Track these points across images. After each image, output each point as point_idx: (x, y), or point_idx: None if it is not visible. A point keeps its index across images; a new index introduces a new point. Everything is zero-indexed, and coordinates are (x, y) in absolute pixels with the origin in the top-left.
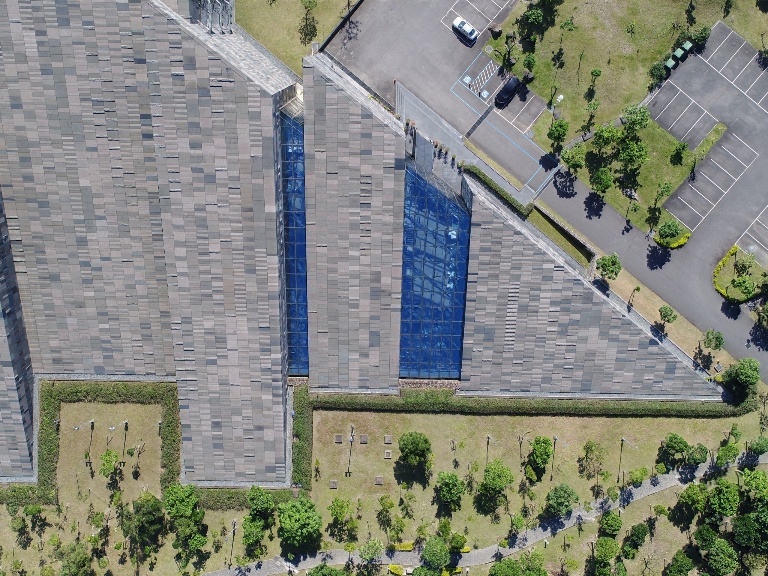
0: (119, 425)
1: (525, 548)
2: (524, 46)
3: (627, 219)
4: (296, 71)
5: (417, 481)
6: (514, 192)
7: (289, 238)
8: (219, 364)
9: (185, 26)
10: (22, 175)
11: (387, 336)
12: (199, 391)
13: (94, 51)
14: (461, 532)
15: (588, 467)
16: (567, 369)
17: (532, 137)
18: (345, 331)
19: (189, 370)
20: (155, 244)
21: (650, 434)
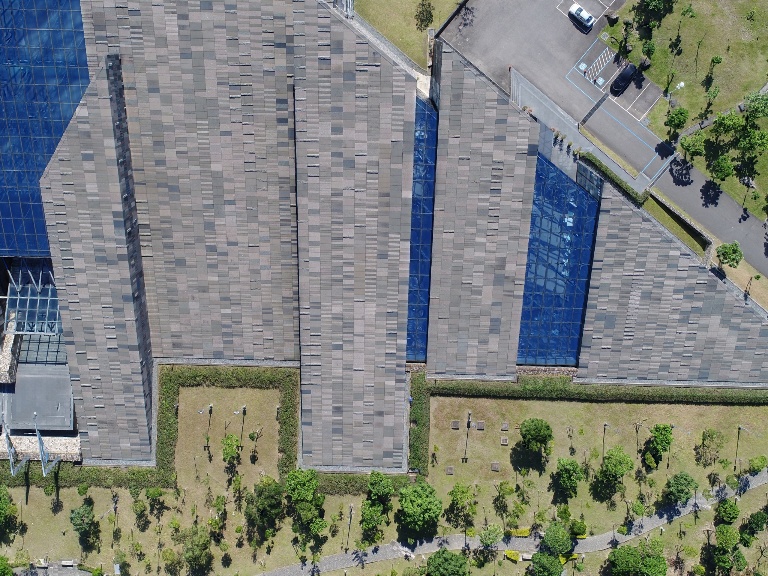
0: (237, 410)
1: (641, 535)
2: (641, 33)
3: (744, 207)
4: (412, 57)
5: (533, 468)
6: (629, 180)
7: (411, 224)
8: (344, 349)
9: (334, 10)
10: (154, 159)
11: (508, 323)
12: (322, 376)
13: (235, 35)
14: (577, 519)
15: (705, 455)
16: (686, 357)
17: (648, 125)
18: (466, 317)
19: (314, 355)
20: (282, 229)
21: (767, 422)
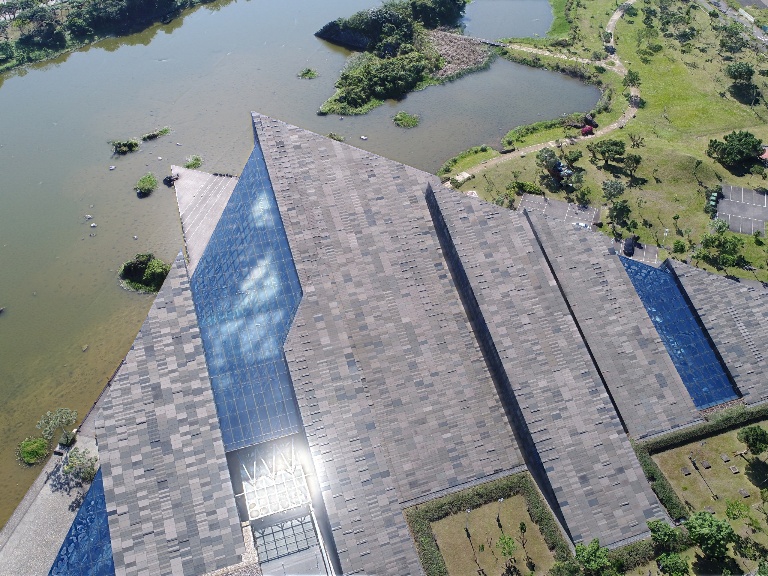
0: (492, 525)
1: None
2: (621, 225)
3: (760, 281)
4: None
5: None
6: None
7: None
8: (563, 417)
9: None
10: (358, 327)
11: (669, 375)
12: (557, 449)
13: (395, 235)
14: None
15: None
16: None
17: None
18: (636, 381)
19: (542, 430)
20: (469, 352)
21: None
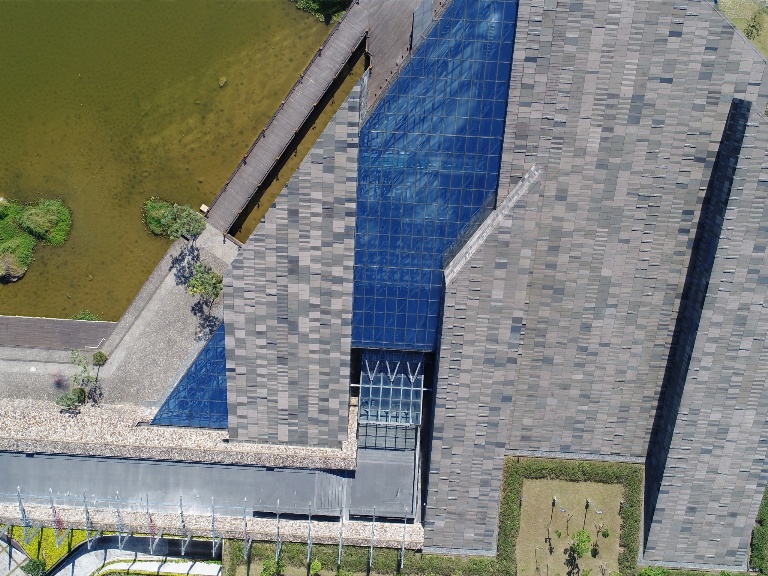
0: (580, 503)
1: None
2: None
3: None
4: None
5: None
6: None
7: None
8: (713, 454)
9: None
10: (546, 263)
11: None
12: (684, 478)
13: (656, 148)
14: None
15: None
16: None
17: None
18: None
19: (681, 458)
20: (659, 333)
21: None
